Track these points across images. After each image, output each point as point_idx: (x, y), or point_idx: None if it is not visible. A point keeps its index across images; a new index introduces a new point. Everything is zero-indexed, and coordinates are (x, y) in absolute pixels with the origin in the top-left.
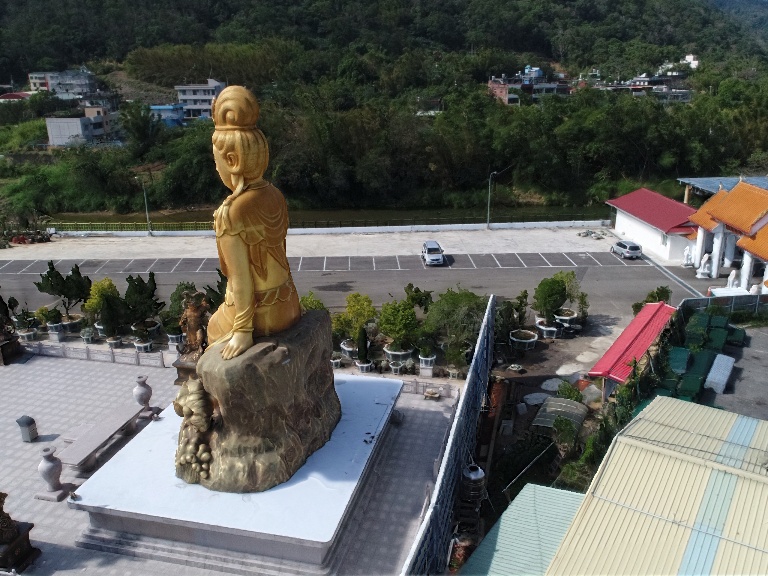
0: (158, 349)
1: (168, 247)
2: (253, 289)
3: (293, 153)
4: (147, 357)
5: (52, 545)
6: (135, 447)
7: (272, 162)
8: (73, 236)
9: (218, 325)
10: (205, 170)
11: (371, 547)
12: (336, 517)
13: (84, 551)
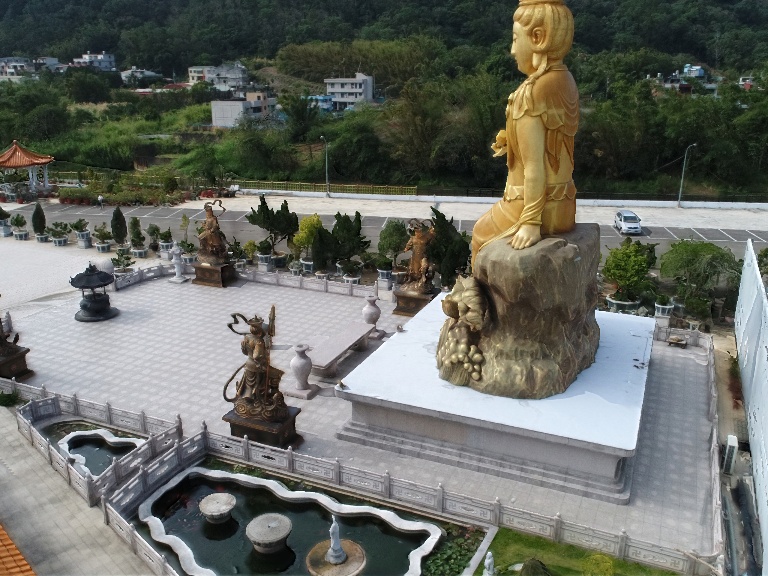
0: (366, 285)
1: (348, 206)
2: (545, 179)
3: (453, 134)
4: (361, 288)
5: (313, 435)
6: (387, 351)
7: (431, 143)
8: (255, 194)
9: (493, 223)
10: (364, 149)
11: (659, 472)
12: (632, 429)
13: (347, 443)
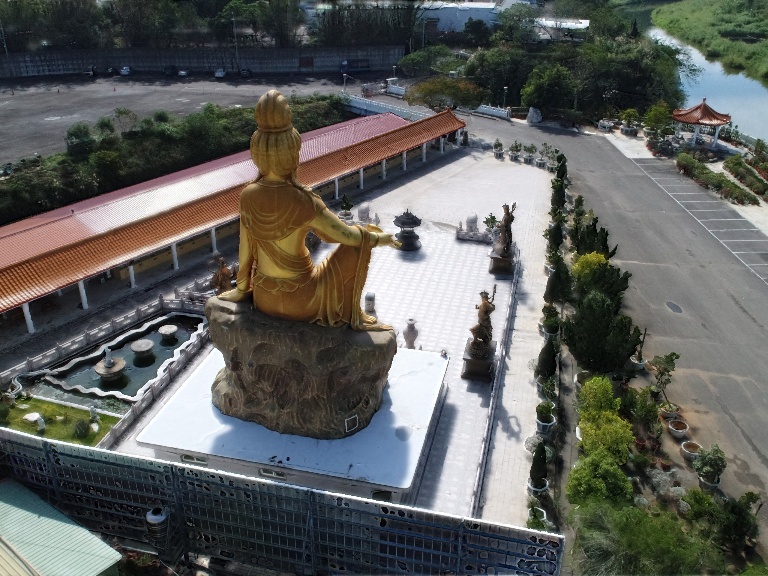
0: None
1: None
2: (247, 262)
3: None
4: None
5: None
6: None
7: None
8: None
9: None
10: None
11: None
12: (164, 442)
13: None
